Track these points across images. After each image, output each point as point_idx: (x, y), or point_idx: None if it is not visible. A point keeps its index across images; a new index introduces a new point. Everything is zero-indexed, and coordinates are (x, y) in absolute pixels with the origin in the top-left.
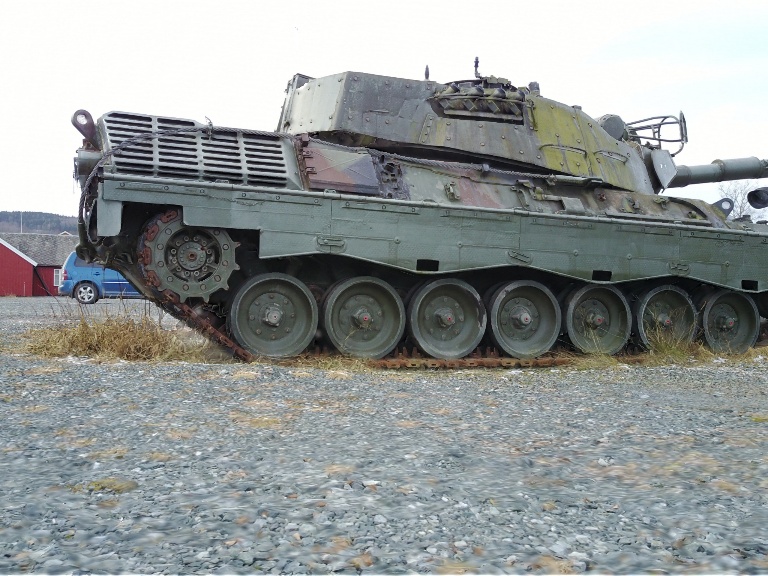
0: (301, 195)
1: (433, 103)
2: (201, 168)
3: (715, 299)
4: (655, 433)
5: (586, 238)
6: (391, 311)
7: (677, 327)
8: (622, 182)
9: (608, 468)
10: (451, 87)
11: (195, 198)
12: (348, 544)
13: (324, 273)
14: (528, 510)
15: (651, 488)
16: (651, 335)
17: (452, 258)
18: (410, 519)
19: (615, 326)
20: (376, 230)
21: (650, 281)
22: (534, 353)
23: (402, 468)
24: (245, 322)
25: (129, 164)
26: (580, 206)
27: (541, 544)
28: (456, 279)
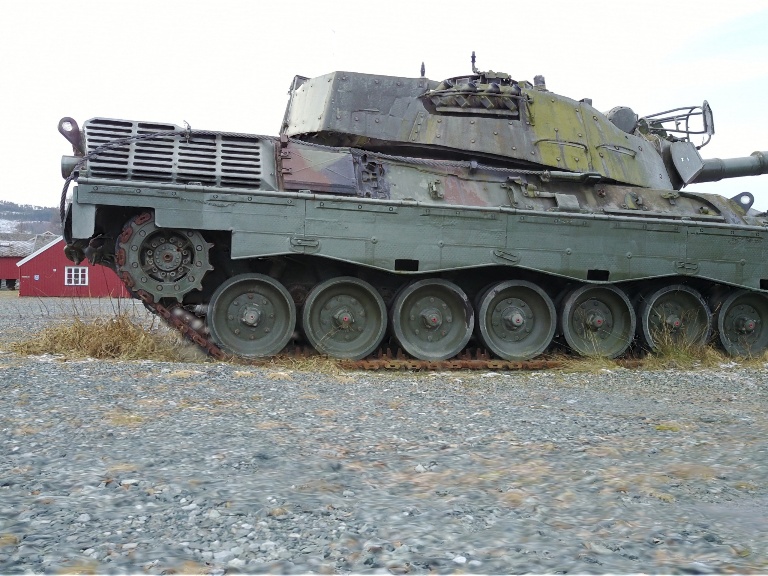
0: (274, 196)
1: (425, 100)
2: (174, 171)
3: (732, 300)
4: (522, 439)
5: (580, 236)
6: (374, 311)
7: (689, 329)
8: (629, 177)
9: (419, 474)
10: (442, 83)
11: (167, 200)
12: (15, 541)
13: (310, 273)
14: (252, 514)
15: (429, 496)
16: (659, 338)
17: (433, 258)
18: (115, 519)
19: (618, 328)
20: (352, 230)
21: (655, 281)
22: (526, 355)
23: (190, 468)
24: (224, 322)
25: (104, 168)
26: (575, 203)
27: (214, 549)
28: (441, 279)
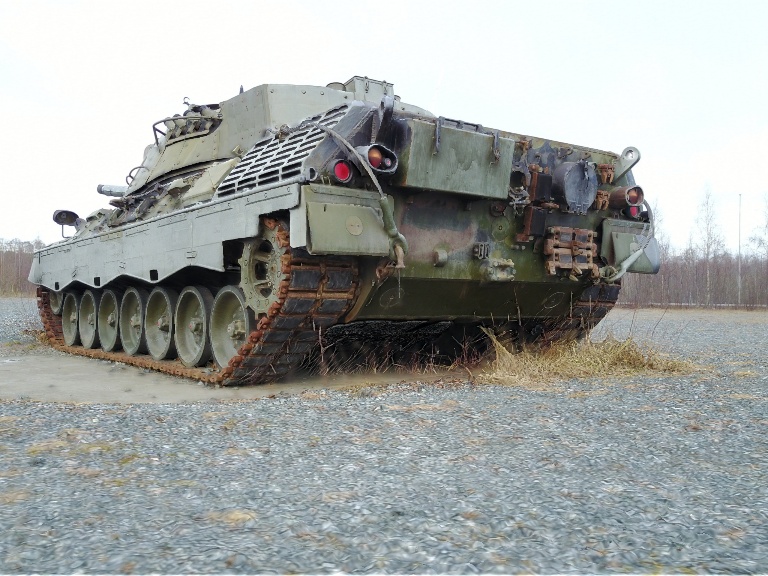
0: None
1: None
2: None
3: None
4: None
5: None
6: None
7: None
8: None
9: None
10: None
11: None
12: None
13: None
14: None
15: None
16: None
17: None
18: None
19: None
20: None
21: None
22: None
23: None
24: None
25: None
26: None
27: None
28: None
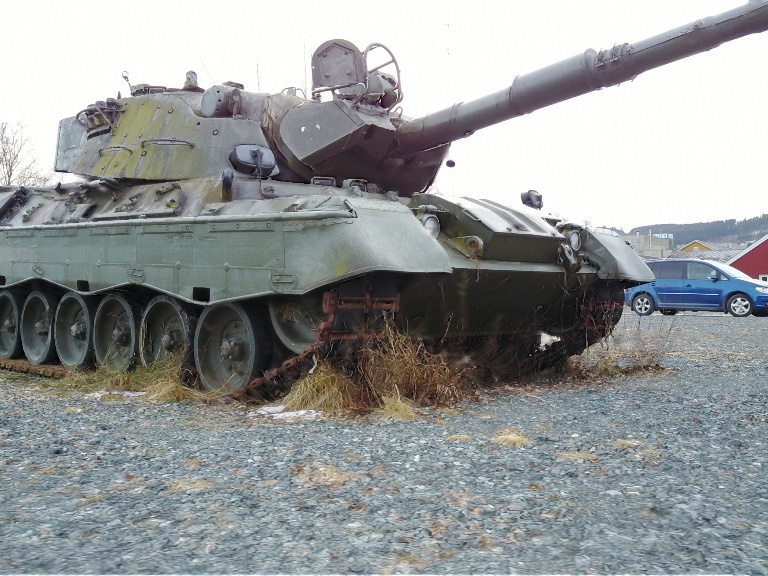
0: None
1: None
2: None
3: (205, 314)
4: None
5: (73, 246)
6: None
7: None
8: (169, 172)
9: None
10: None
11: None
12: None
13: None
14: None
15: None
16: None
17: None
18: None
19: None
20: None
21: (132, 291)
22: (73, 365)
23: None
24: None
25: None
26: None
27: None
28: None
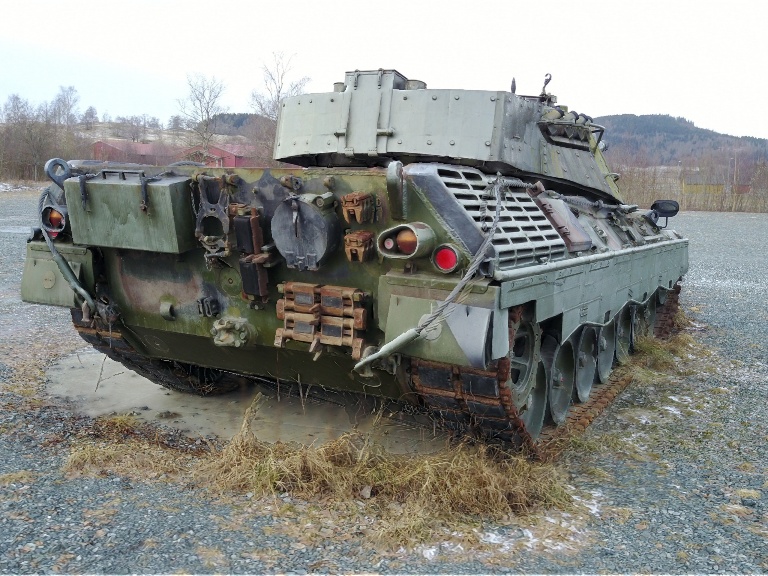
0: (578, 264)
1: (541, 127)
2: (533, 246)
3: None
4: None
5: None
6: (561, 364)
7: None
8: None
9: None
10: (559, 112)
11: (541, 288)
12: None
13: None
14: None
15: None
16: None
17: (614, 305)
18: None
19: None
20: (596, 290)
21: None
22: None
23: None
24: None
25: (503, 253)
26: None
27: None
28: None
